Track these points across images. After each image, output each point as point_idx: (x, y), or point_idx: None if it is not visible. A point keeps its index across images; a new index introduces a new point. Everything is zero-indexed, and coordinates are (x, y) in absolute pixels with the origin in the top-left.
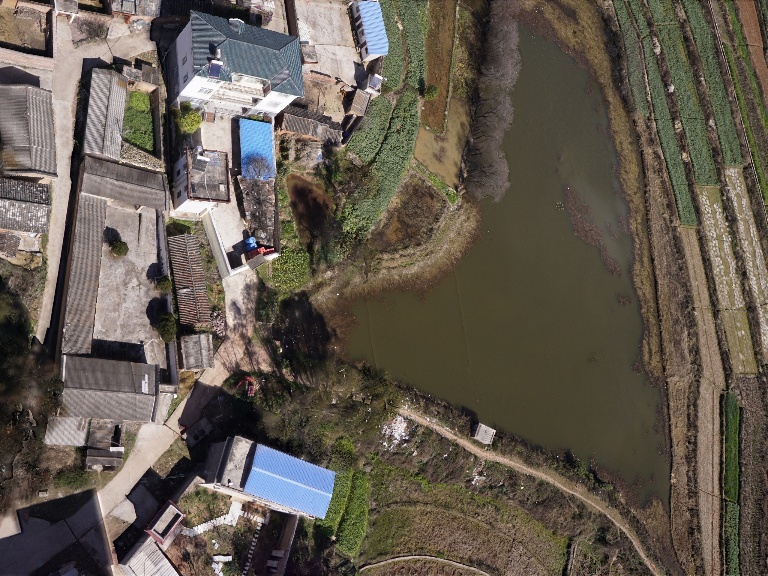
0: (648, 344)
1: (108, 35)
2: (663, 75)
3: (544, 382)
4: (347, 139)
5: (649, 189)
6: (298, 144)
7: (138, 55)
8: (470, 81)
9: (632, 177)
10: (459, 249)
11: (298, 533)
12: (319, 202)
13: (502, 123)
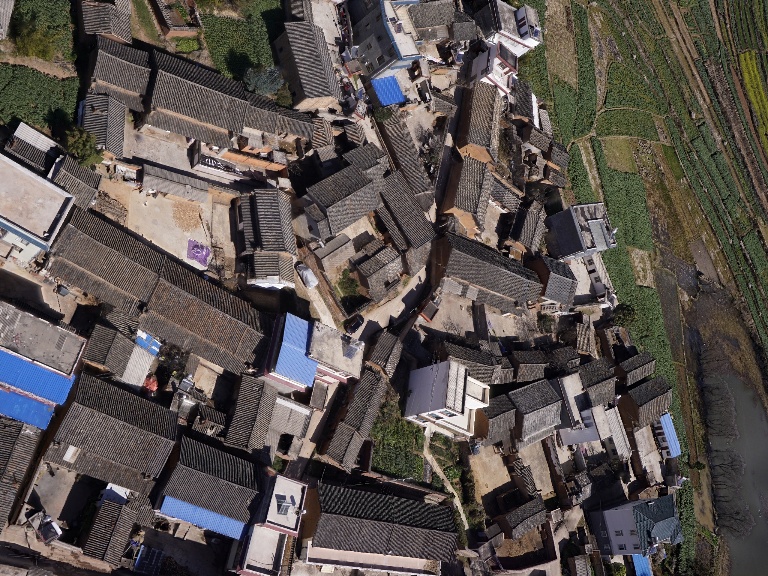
0: None
1: (564, 517)
2: None
3: None
4: None
5: None
6: None
7: (578, 524)
8: (704, 436)
9: None
10: None
11: None
12: None
13: (739, 477)
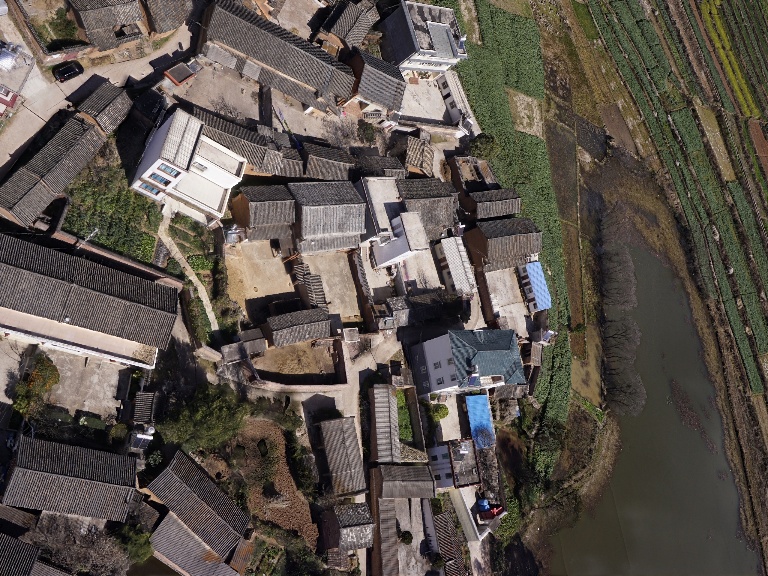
0: (744, 511)
1: (371, 346)
2: (723, 259)
3: (680, 568)
4: (532, 390)
5: (726, 367)
6: (502, 405)
7: (391, 357)
8: (597, 304)
9: (713, 358)
10: (610, 462)
11: None
12: (516, 448)
13: (633, 346)
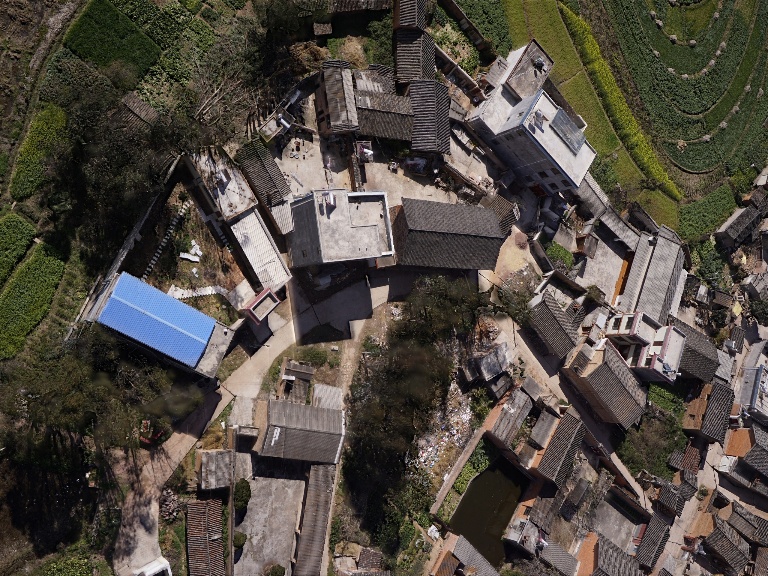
0: None
1: None
2: None
3: None
4: None
5: None
6: None
7: None
8: None
9: None
10: None
11: (95, 259)
12: None
13: None
